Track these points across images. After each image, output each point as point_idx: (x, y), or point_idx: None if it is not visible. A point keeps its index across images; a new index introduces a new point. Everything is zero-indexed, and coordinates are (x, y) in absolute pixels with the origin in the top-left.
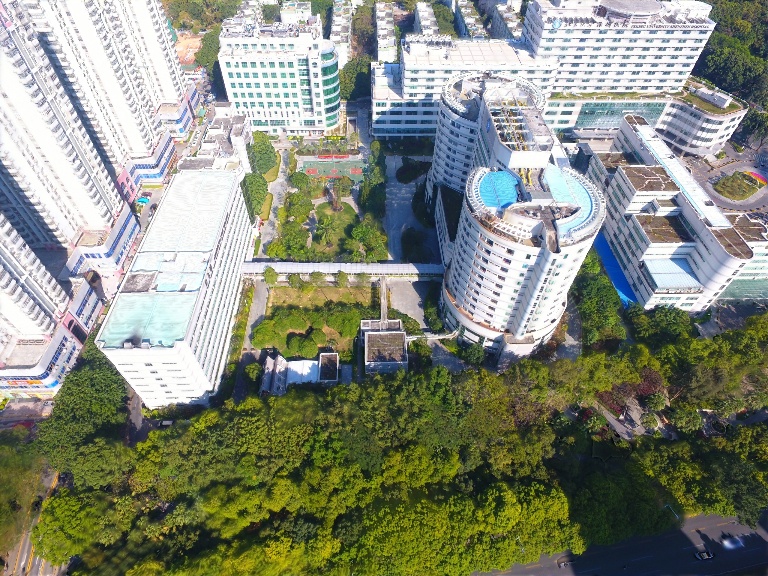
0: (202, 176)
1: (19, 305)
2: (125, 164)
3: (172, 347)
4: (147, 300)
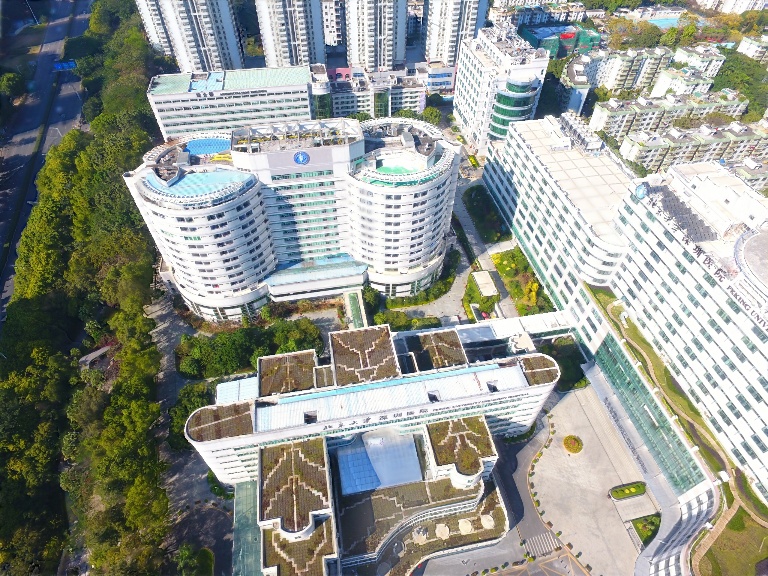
0: (303, 74)
1: (192, 56)
2: (356, 67)
3: (147, 93)
4: (185, 81)
